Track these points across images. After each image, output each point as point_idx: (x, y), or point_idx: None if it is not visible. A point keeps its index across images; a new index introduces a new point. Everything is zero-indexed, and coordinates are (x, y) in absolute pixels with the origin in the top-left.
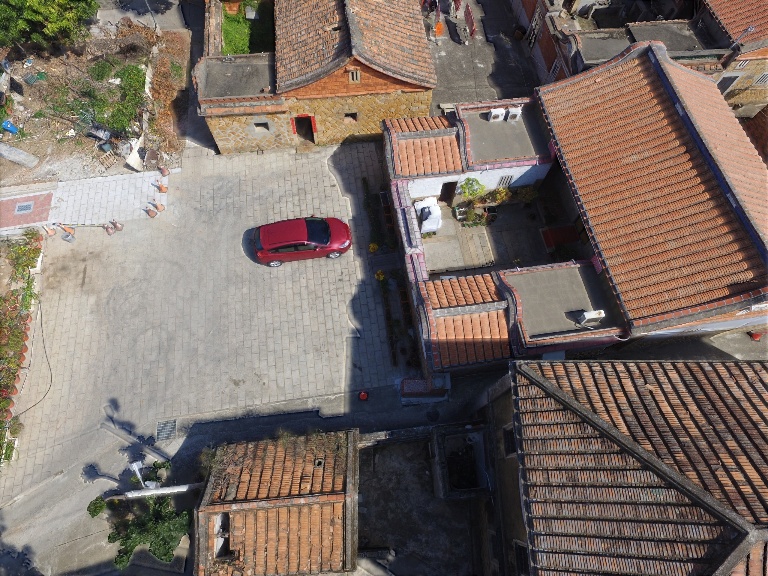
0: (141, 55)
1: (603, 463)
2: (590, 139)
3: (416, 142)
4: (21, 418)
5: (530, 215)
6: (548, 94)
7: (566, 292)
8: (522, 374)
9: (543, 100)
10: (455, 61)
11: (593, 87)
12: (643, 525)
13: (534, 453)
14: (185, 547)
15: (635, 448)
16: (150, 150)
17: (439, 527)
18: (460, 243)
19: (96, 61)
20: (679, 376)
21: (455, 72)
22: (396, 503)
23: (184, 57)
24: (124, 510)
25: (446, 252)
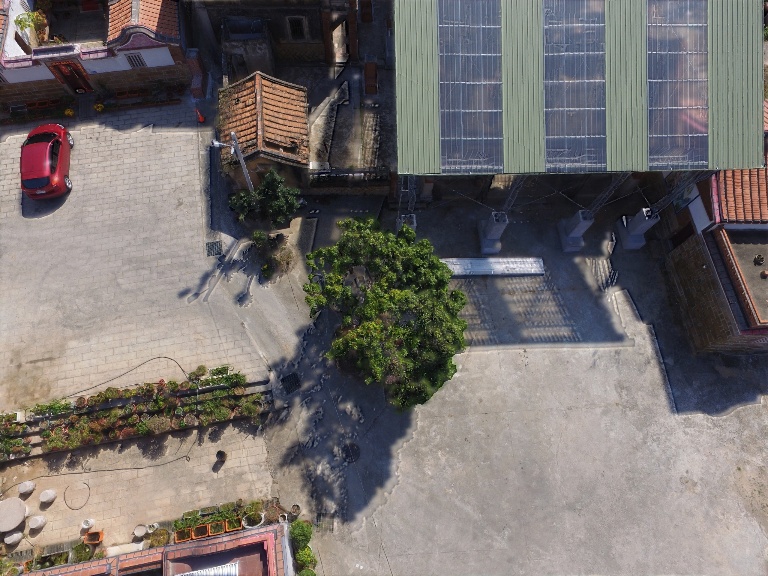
0: None
1: None
2: None
3: None
4: None
5: (65, 15)
6: None
7: None
8: None
9: None
10: None
11: None
12: None
13: None
14: (301, 220)
15: None
16: None
17: (293, 82)
18: None
19: None
20: None
21: None
22: None
23: None
24: (273, 264)
25: None
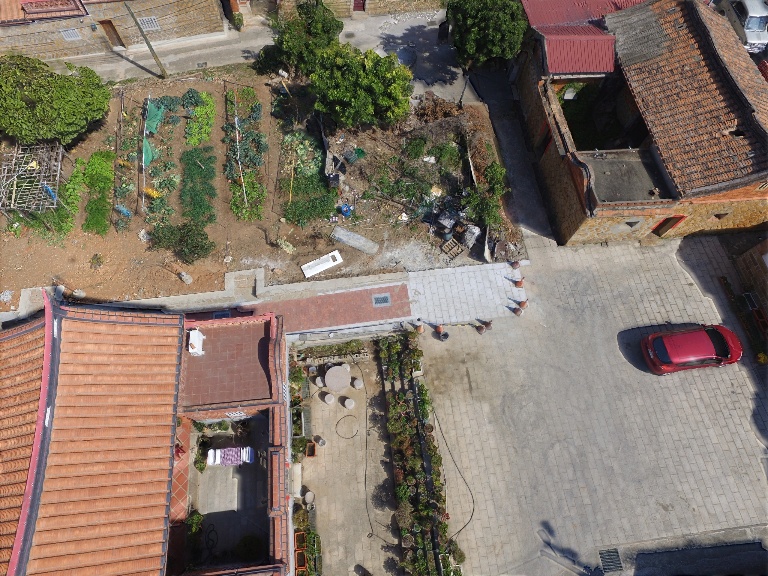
0: (449, 131)
1: None
2: None
3: None
4: (457, 542)
5: None
6: None
7: None
8: None
9: None
10: None
11: None
12: None
13: None
14: None
15: None
16: (500, 241)
17: None
18: None
19: (405, 137)
20: None
21: None
22: None
23: (488, 134)
24: None
25: None
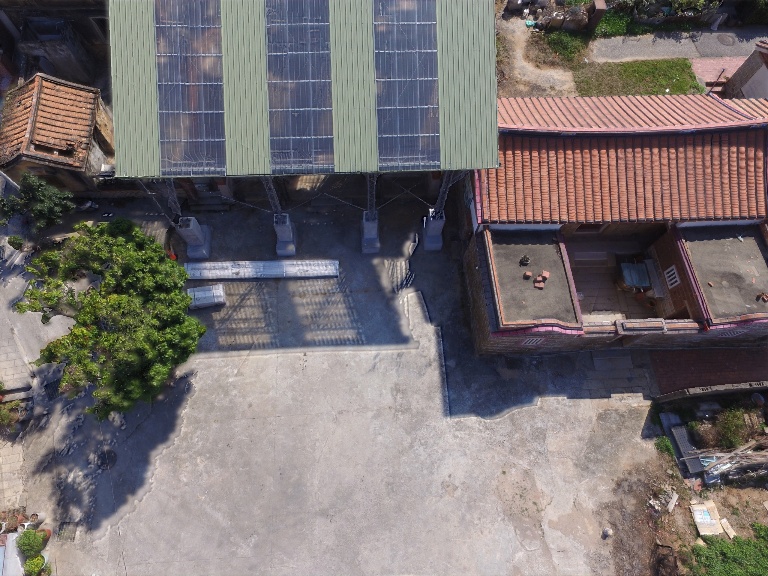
0: None
1: None
2: None
3: None
4: None
5: None
6: None
7: None
8: None
9: None
10: None
11: None
12: None
13: None
14: (92, 223)
15: None
16: None
17: None
18: None
19: None
20: None
21: None
22: None
23: None
24: (53, 268)
25: None
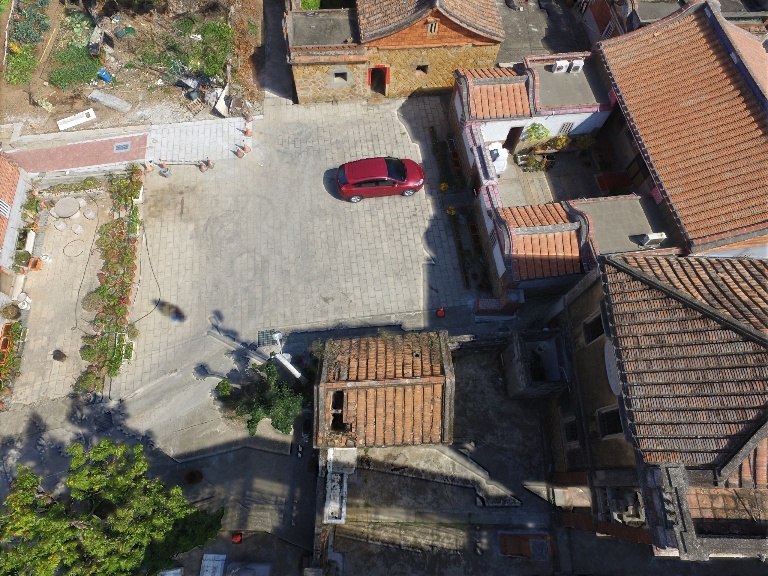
0: (219, 14)
1: (687, 327)
2: (650, 86)
3: (490, 88)
4: (136, 325)
5: (585, 162)
6: (609, 47)
7: (629, 219)
8: (611, 264)
9: (604, 53)
10: (511, 25)
11: (652, 40)
12: (724, 370)
13: (624, 324)
14: (290, 434)
15: (716, 312)
16: (235, 98)
17: (512, 424)
18: (522, 186)
19: (178, 19)
20: (745, 269)
21: (511, 35)
22: (474, 403)
23: (258, 17)
24: (234, 402)
25: (510, 193)
